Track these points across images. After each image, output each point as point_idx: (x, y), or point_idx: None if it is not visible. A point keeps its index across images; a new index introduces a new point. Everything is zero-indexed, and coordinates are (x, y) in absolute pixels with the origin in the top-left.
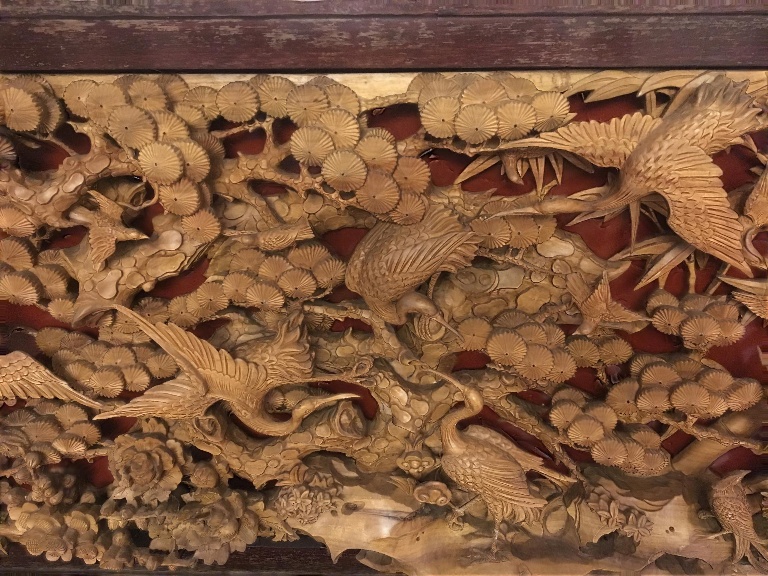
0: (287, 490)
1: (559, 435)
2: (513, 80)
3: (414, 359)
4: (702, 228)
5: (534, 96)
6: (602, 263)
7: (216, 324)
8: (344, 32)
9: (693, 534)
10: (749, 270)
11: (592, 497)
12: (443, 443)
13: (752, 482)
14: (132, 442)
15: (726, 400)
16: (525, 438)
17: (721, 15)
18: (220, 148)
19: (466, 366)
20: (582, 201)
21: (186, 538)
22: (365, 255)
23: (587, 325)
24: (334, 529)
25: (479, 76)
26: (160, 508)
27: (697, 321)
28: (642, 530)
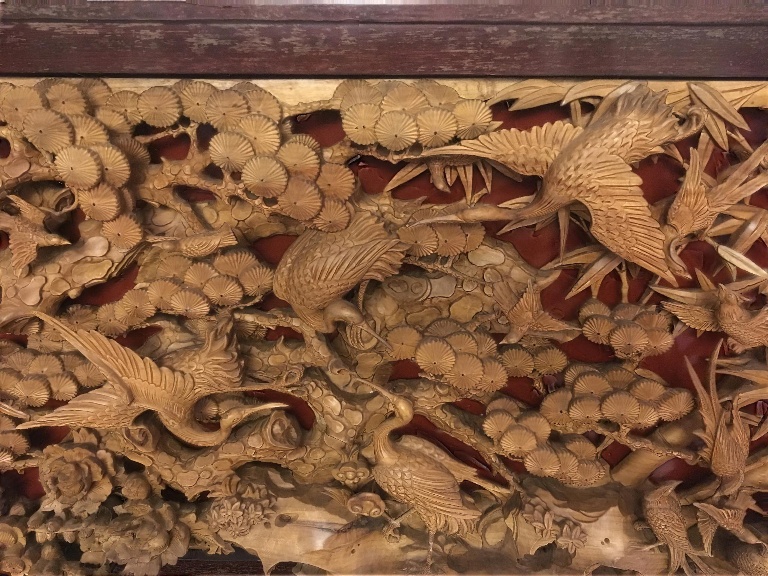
0: (219, 502)
1: (494, 445)
2: (435, 87)
3: (343, 368)
4: (625, 237)
5: (456, 104)
6: (533, 272)
7: (148, 332)
8: (266, 38)
9: (628, 545)
10: (674, 279)
11: (527, 508)
12: (375, 453)
13: (689, 493)
14: (62, 453)
15: (657, 410)
16: (462, 448)
17: (640, 25)
18: (144, 153)
19: (402, 375)
20: (505, 209)
21: (116, 551)
22: (292, 262)
23: (514, 334)
24: (267, 541)
25: (403, 83)
26: (87, 520)
27: (625, 330)
28: (576, 542)
